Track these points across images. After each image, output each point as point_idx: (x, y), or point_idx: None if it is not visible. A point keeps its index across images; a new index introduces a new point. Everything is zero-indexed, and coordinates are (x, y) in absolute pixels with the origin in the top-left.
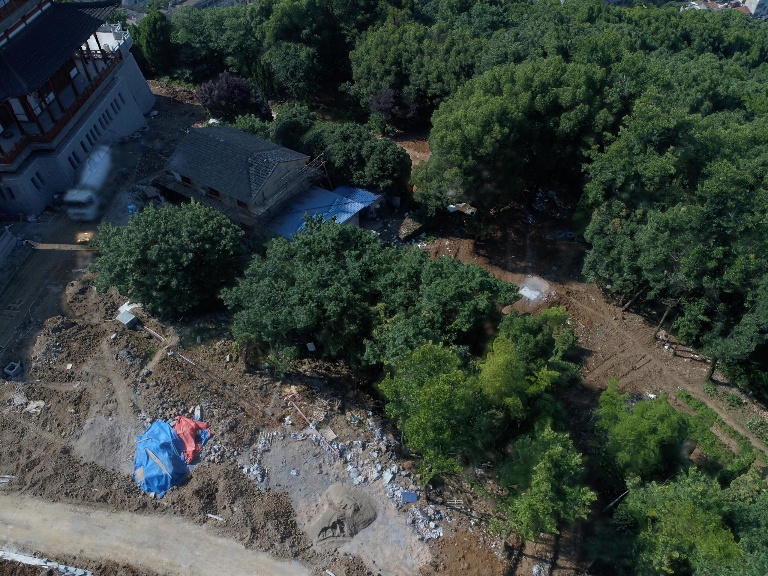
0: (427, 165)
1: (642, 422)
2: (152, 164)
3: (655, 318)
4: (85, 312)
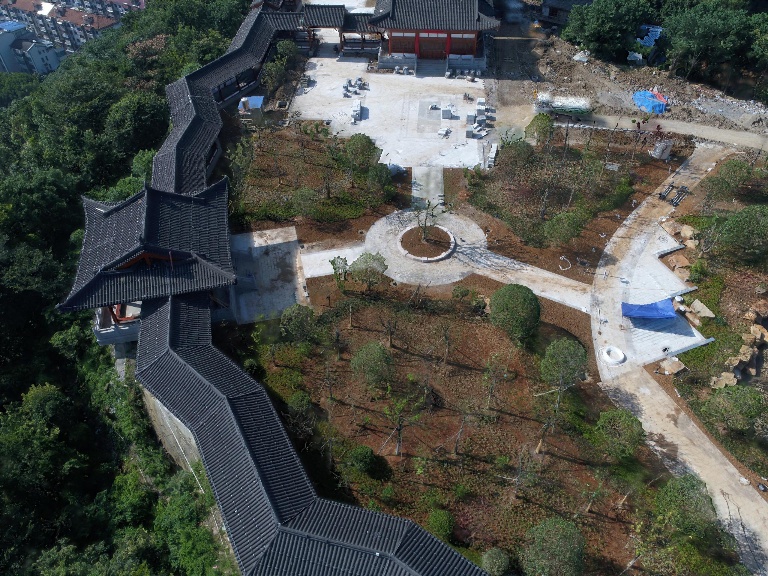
0: (710, 2)
1: None
2: (523, 8)
3: None
4: (554, 59)
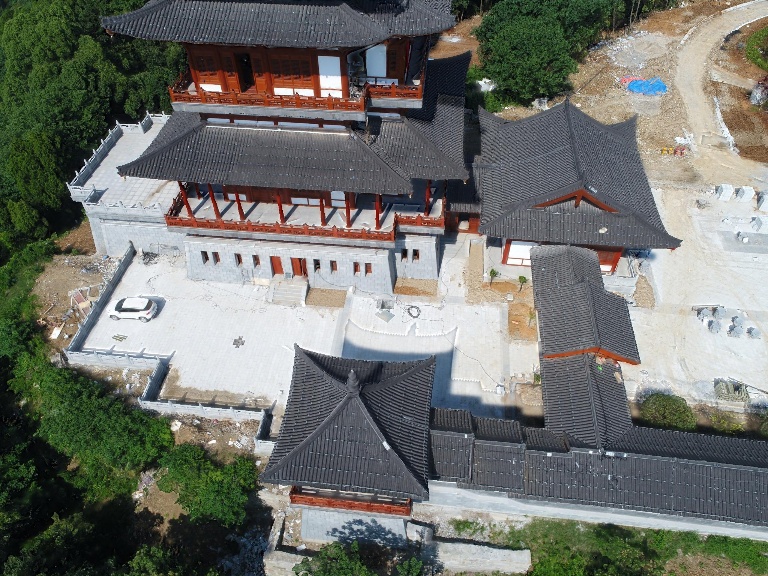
0: None
1: None
2: None
3: (465, 17)
4: None
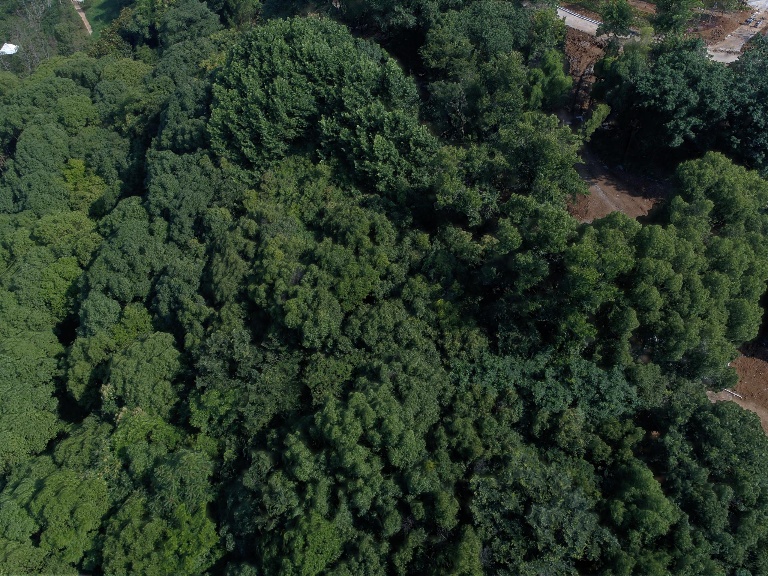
0: None
1: (558, 61)
2: None
3: None
4: None
